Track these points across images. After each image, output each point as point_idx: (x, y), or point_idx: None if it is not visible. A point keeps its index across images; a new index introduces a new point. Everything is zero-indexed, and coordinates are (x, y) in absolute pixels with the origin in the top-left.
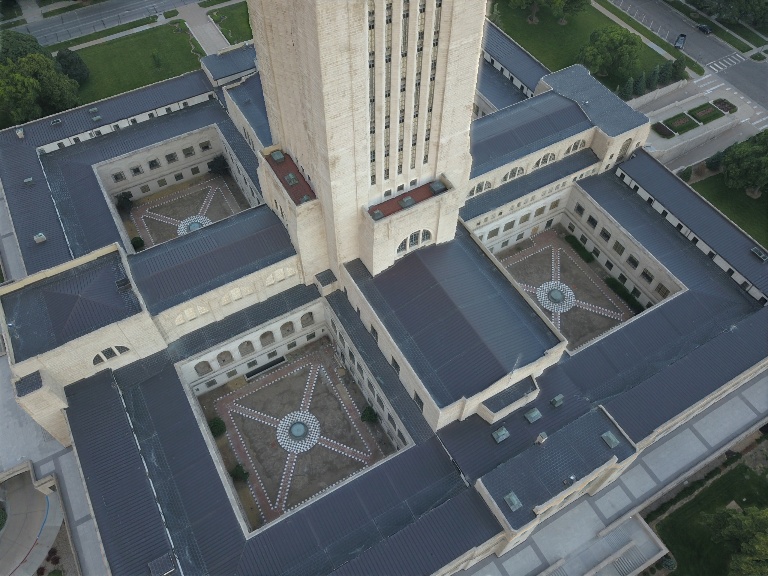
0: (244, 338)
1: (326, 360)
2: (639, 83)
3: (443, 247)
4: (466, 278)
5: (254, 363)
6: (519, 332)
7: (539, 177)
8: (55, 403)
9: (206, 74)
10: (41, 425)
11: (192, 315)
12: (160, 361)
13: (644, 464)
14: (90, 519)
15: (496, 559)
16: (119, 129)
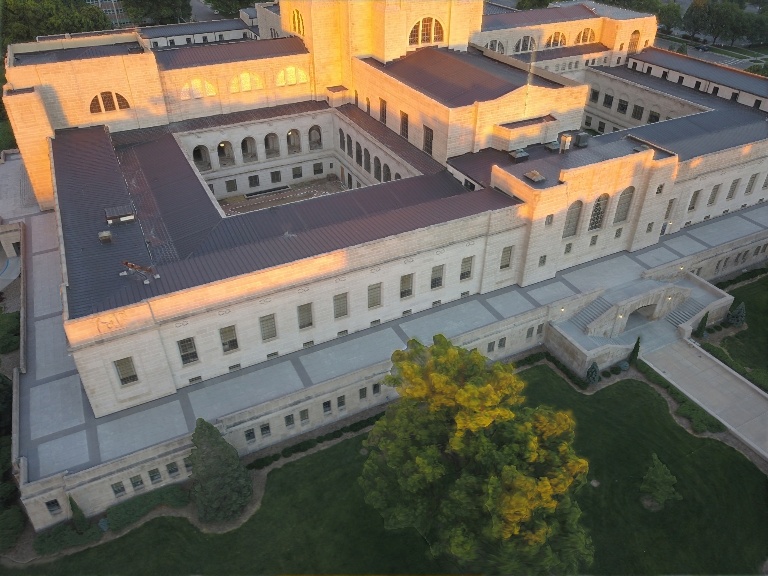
0: (248, 130)
1: (332, 189)
2: None
3: (456, 53)
4: (479, 63)
5: (256, 182)
6: (535, 84)
7: (551, 54)
8: (42, 124)
9: (243, 20)
10: (22, 154)
11: (199, 93)
12: (159, 133)
13: (690, 235)
14: (50, 252)
15: (519, 289)
16: (158, 47)
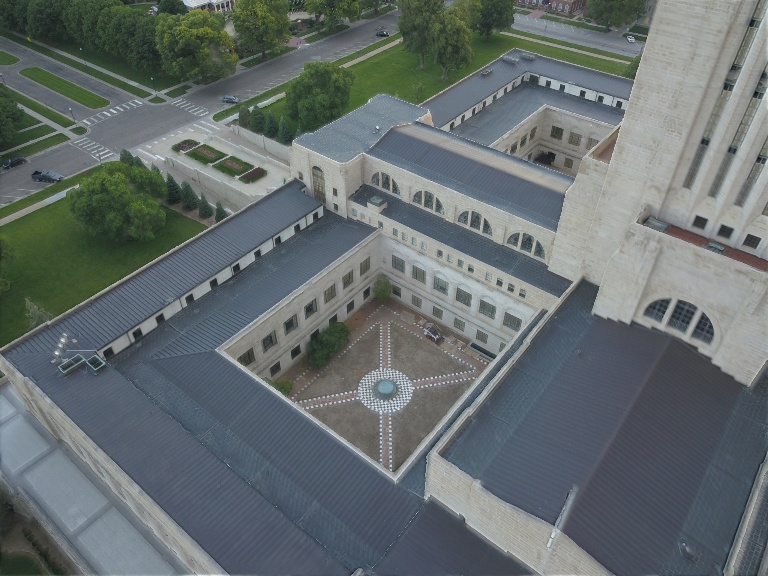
0: None
1: None
2: (177, 186)
3: None
4: None
5: None
6: None
7: None
8: None
9: None
10: None
11: None
12: None
13: None
14: None
15: None
16: None
